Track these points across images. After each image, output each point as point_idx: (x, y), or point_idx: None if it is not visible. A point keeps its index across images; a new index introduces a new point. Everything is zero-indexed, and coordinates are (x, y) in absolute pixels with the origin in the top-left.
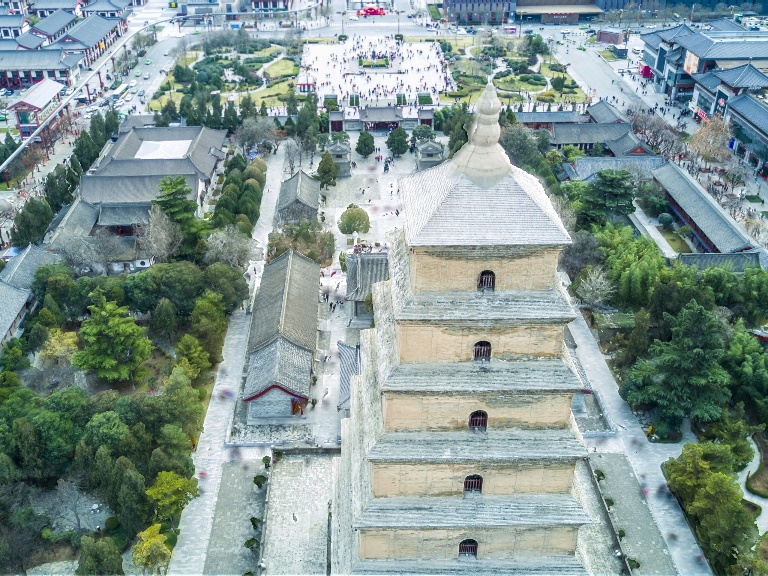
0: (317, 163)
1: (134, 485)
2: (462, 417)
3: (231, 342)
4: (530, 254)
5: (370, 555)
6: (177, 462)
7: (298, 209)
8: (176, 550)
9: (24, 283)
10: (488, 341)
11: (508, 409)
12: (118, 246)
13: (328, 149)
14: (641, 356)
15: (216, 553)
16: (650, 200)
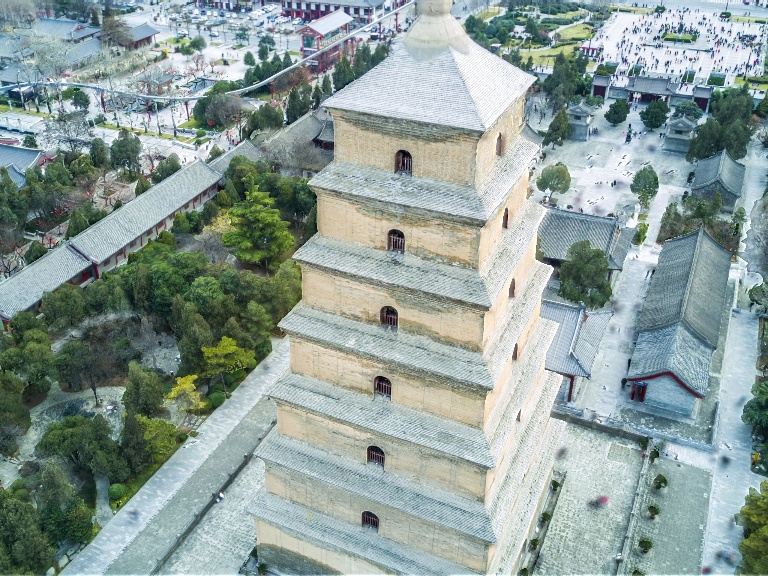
0: None
1: (197, 340)
2: (373, 309)
3: None
4: (446, 138)
5: (287, 432)
6: (248, 336)
7: None
8: (219, 410)
9: (225, 170)
10: (402, 231)
11: (418, 312)
12: (315, 156)
13: None
14: None
15: (248, 423)
16: None
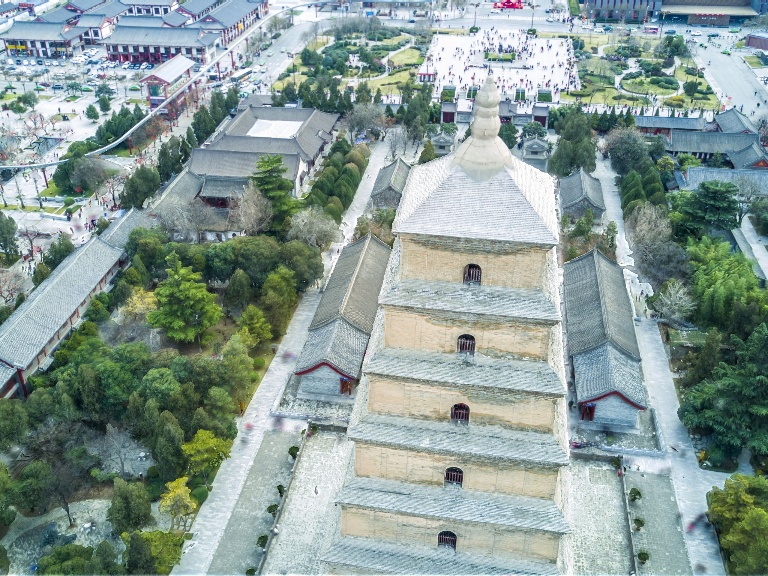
0: None
1: (172, 438)
2: (444, 408)
3: (299, 318)
4: (516, 251)
5: (351, 532)
6: (218, 423)
7: (390, 196)
8: (205, 505)
9: (121, 243)
10: (472, 335)
11: (490, 406)
12: (211, 216)
13: (432, 139)
14: (709, 378)
15: (241, 513)
16: (762, 217)
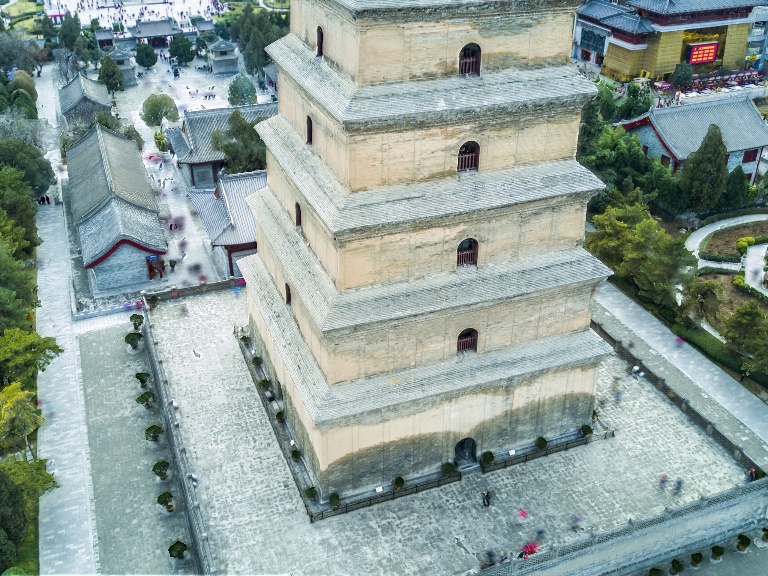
0: (93, 79)
1: None
2: (451, 56)
3: (45, 231)
4: None
5: (351, 283)
6: None
7: (87, 109)
8: (42, 430)
9: None
10: None
11: (504, 38)
12: None
13: (106, 55)
14: None
15: (99, 421)
16: None
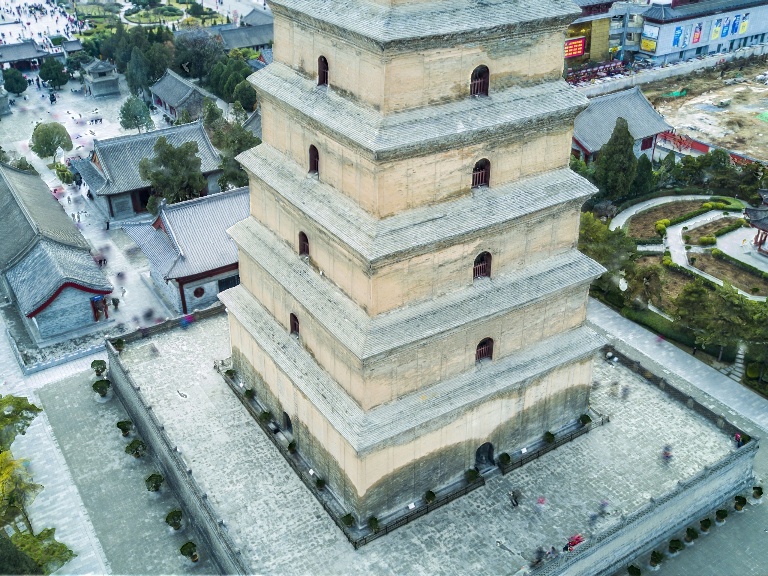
0: None
1: None
2: (464, 78)
3: None
4: None
5: (382, 307)
6: None
7: None
8: None
9: None
10: None
11: (509, 58)
12: None
13: None
14: None
15: (89, 479)
16: None
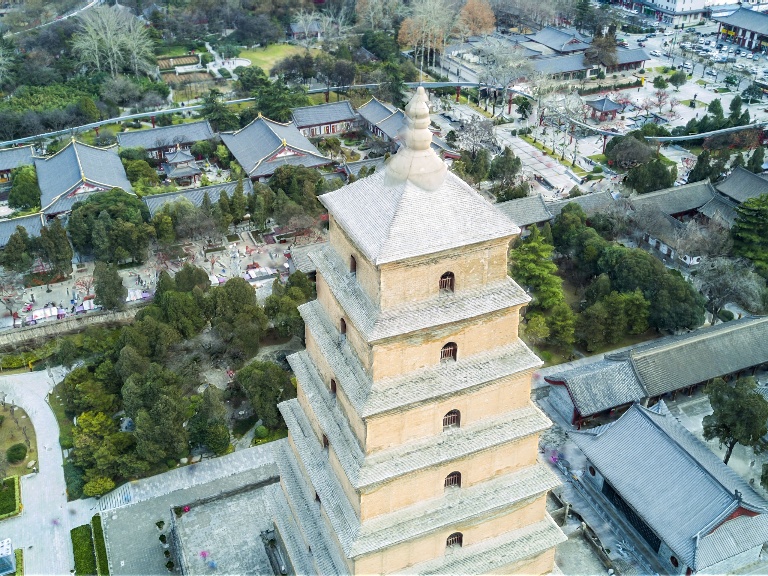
0: None
1: None
2: None
3: None
4: None
5: None
6: None
7: None
8: None
9: None
10: None
11: None
12: (661, 227)
13: None
14: None
15: None
16: None
